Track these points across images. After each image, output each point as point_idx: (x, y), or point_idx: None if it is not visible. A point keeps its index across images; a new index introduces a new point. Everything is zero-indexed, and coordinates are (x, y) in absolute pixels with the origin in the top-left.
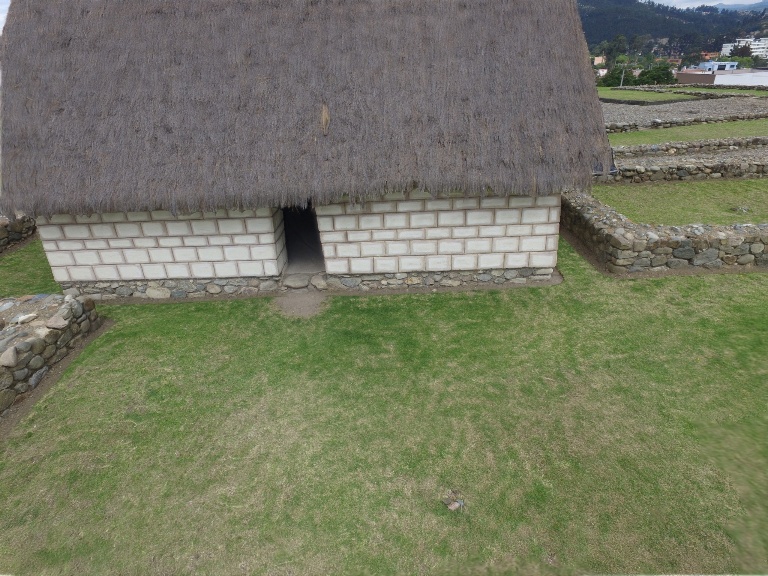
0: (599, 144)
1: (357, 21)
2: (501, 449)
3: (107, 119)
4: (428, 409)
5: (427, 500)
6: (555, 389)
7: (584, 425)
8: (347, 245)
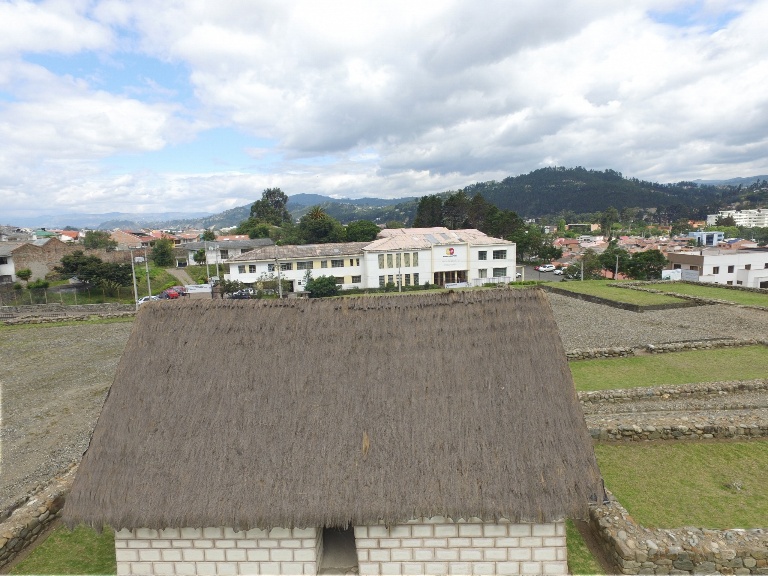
0: (591, 475)
1: (390, 354)
2: None
3: (190, 440)
4: None
5: None
6: None
7: None
8: (379, 551)
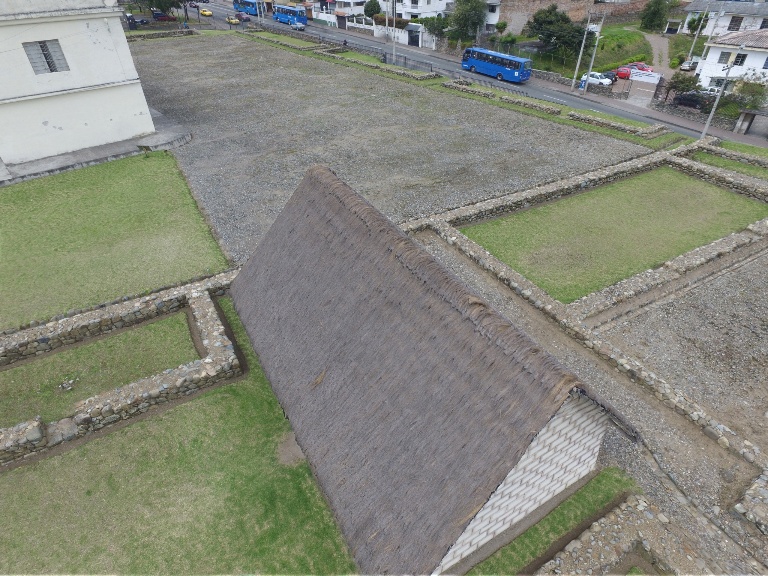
0: None
1: (385, 325)
2: None
3: None
4: None
5: None
6: None
7: None
8: None
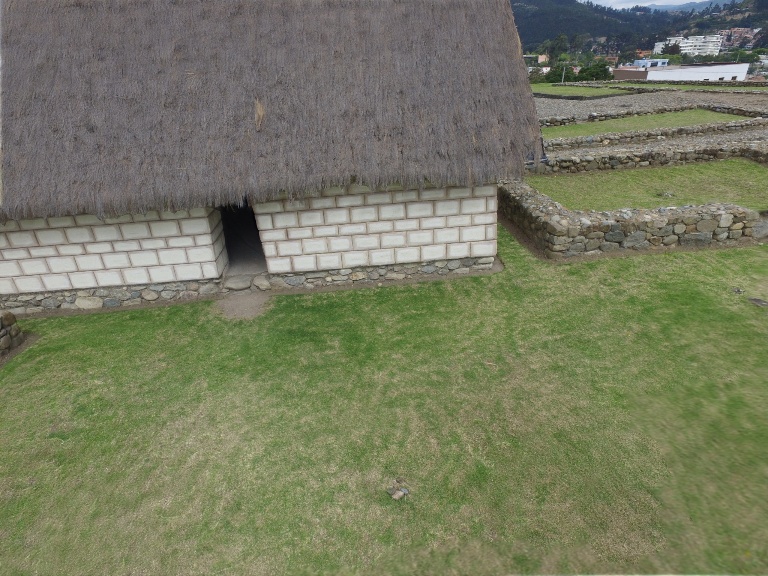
0: (529, 134)
1: (286, 15)
2: (445, 435)
3: (20, 119)
4: (373, 402)
5: (372, 492)
6: (496, 373)
7: (524, 406)
8: (288, 243)
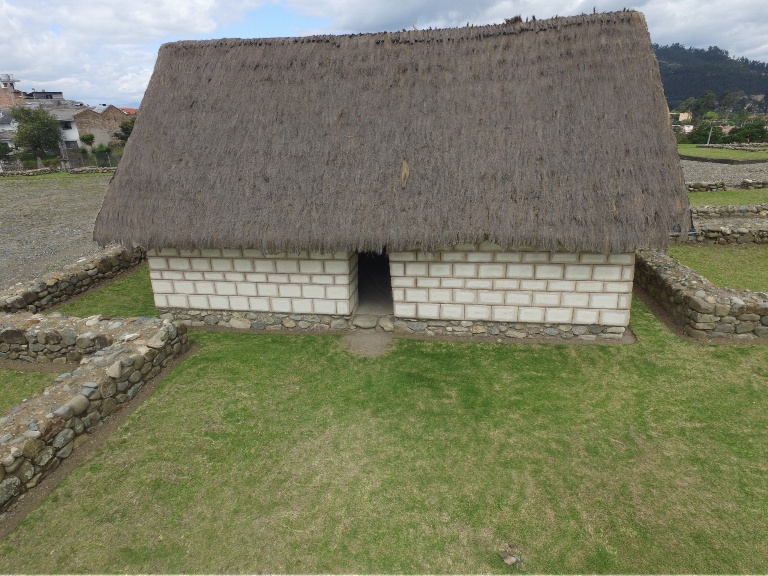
0: (677, 206)
1: (439, 87)
2: (562, 509)
3: (216, 169)
4: (487, 459)
5: (482, 551)
6: (623, 453)
7: (654, 494)
8: (416, 291)
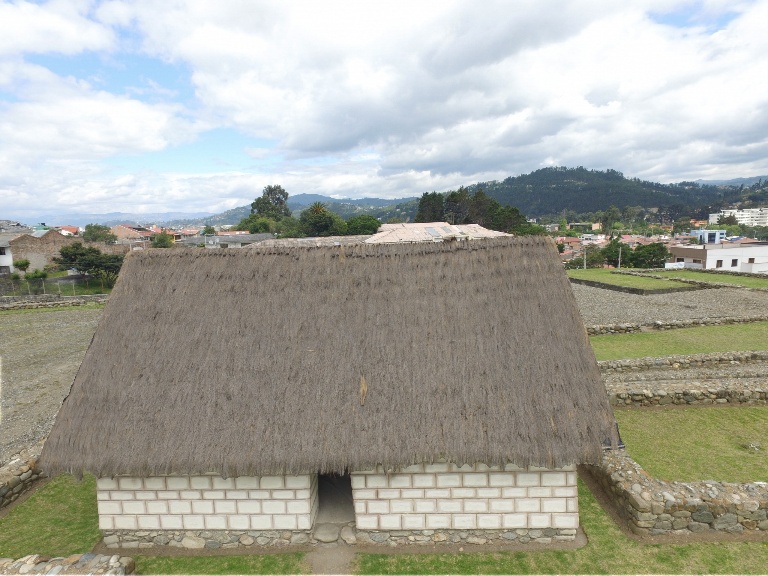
0: (604, 419)
1: (390, 301)
2: None
3: (177, 385)
4: None
5: None
6: None
7: None
8: (377, 502)
